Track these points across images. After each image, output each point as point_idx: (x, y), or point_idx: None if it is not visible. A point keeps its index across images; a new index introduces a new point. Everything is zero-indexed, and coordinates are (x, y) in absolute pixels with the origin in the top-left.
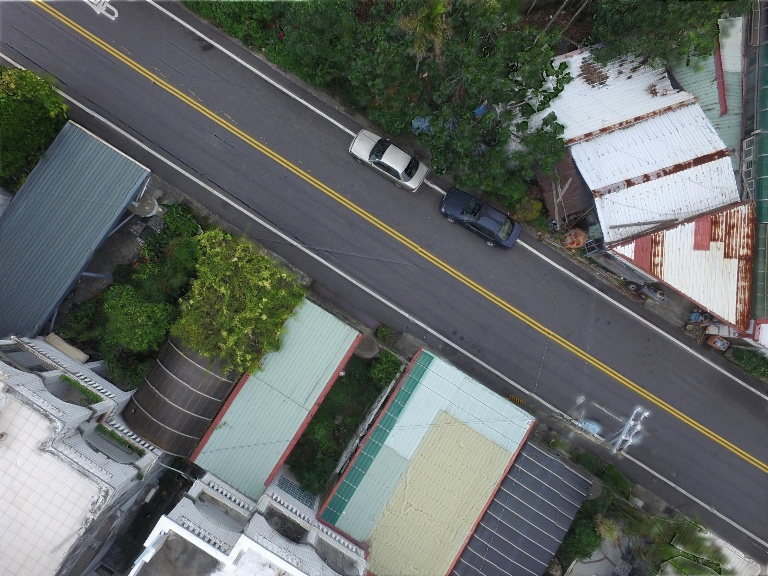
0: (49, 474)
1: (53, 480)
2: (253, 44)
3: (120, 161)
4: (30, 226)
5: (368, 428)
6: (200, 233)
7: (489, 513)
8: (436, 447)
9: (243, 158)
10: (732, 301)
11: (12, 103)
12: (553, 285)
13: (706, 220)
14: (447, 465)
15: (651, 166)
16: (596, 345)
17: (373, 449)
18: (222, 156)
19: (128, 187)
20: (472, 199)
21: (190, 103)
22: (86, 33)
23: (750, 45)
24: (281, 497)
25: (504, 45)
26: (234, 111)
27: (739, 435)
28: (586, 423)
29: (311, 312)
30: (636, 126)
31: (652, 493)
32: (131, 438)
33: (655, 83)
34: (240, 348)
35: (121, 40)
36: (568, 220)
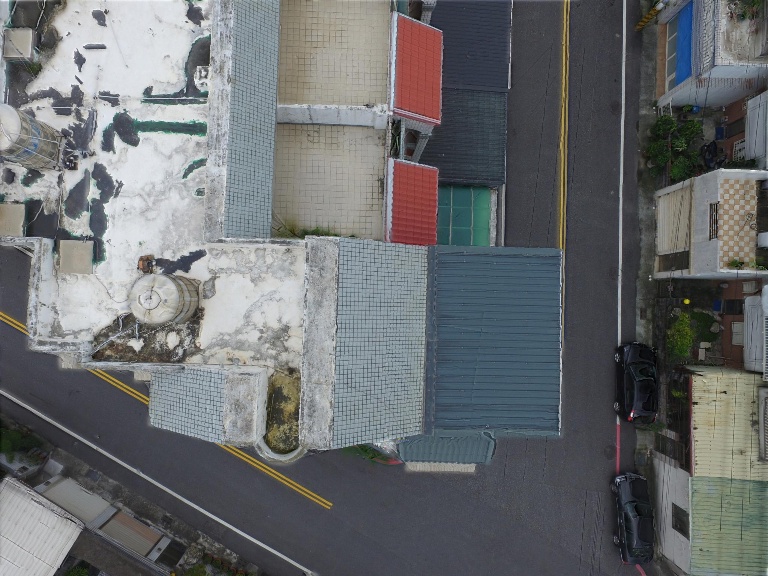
0: None
1: None
2: None
3: None
4: None
5: None
6: None
7: None
8: None
9: None
10: None
11: None
12: None
13: None
14: None
15: None
16: (15, 304)
17: None
18: None
19: None
20: None
21: None
22: None
23: None
24: None
25: None
26: None
27: None
28: None
29: None
30: None
31: (73, 456)
32: None
33: None
34: None
35: None
36: None
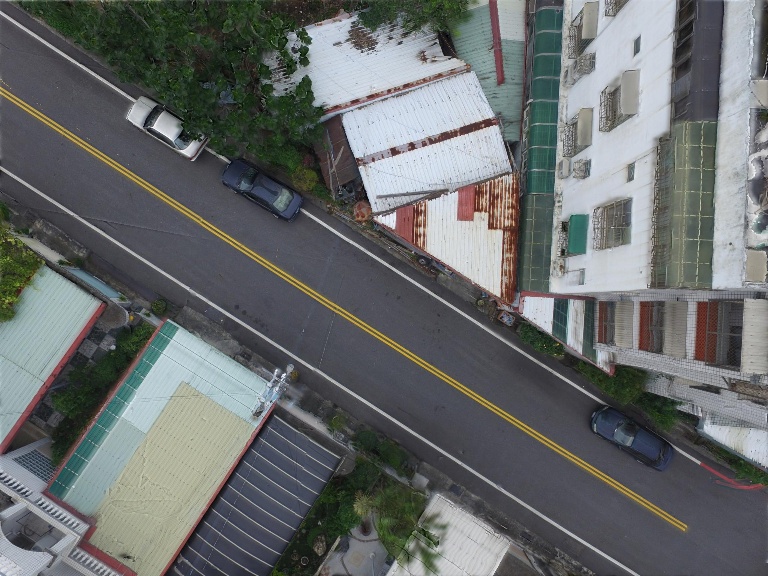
0: None
1: None
2: None
3: None
4: None
5: None
6: None
7: (230, 487)
8: (177, 420)
9: (18, 124)
10: (497, 273)
11: None
12: (342, 259)
13: (469, 190)
14: (188, 438)
15: (418, 134)
16: (384, 320)
17: (110, 422)
18: None
19: None
20: (250, 169)
21: None
22: None
23: (529, 12)
24: (5, 470)
25: None
26: (8, 75)
27: (528, 412)
28: None
29: (52, 280)
30: (410, 94)
31: (438, 471)
32: None
33: (425, 49)
34: None
35: None
36: (354, 192)
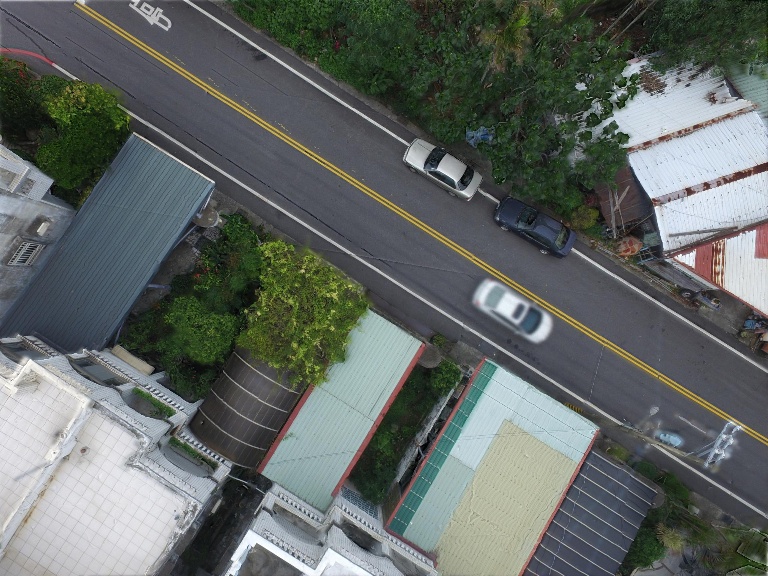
0: (131, 488)
1: (136, 494)
2: (306, 54)
3: (185, 173)
4: (96, 239)
5: (428, 437)
6: (262, 244)
7: (555, 523)
8: (501, 457)
9: (297, 168)
10: None
11: (83, 117)
12: (607, 293)
13: (767, 228)
14: (512, 475)
15: (711, 174)
16: (650, 353)
17: (439, 459)
18: (276, 166)
19: (193, 199)
20: (527, 207)
21: (244, 113)
22: (140, 44)
23: None
24: (349, 508)
25: None
26: (288, 121)
27: None
28: (667, 435)
29: (374, 322)
30: (694, 134)
31: (708, 500)
32: (202, 450)
33: (713, 91)
34: (309, 360)
35: (175, 50)
36: (622, 228)
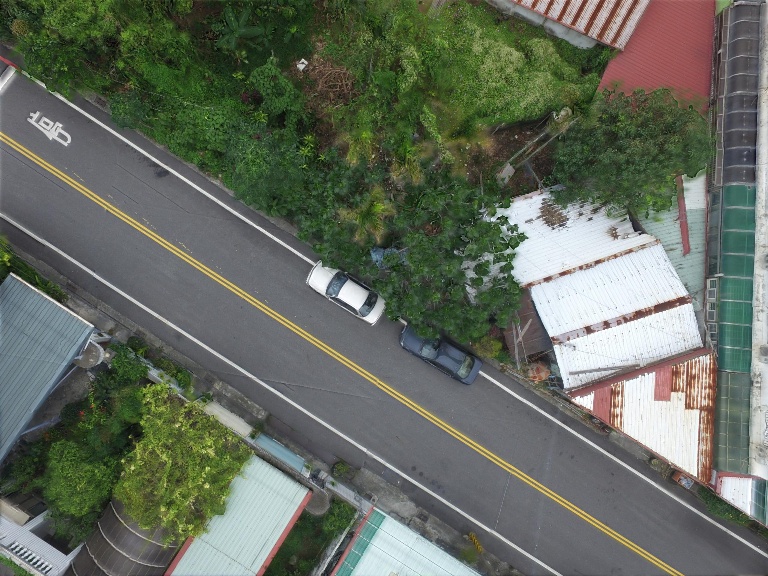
0: None
1: None
2: (209, 170)
3: (62, 316)
4: None
5: None
6: (146, 385)
7: None
8: None
9: (198, 288)
10: (693, 452)
11: None
12: (515, 418)
13: (667, 370)
14: None
15: (611, 312)
16: (559, 480)
17: None
18: (176, 286)
19: (70, 344)
20: None
21: (144, 232)
22: (37, 160)
23: (714, 184)
24: None
25: (452, 218)
26: (189, 240)
27: (704, 573)
28: None
29: (260, 468)
30: (597, 267)
31: None
32: None
33: (616, 225)
34: (181, 520)
35: (74, 167)
36: None
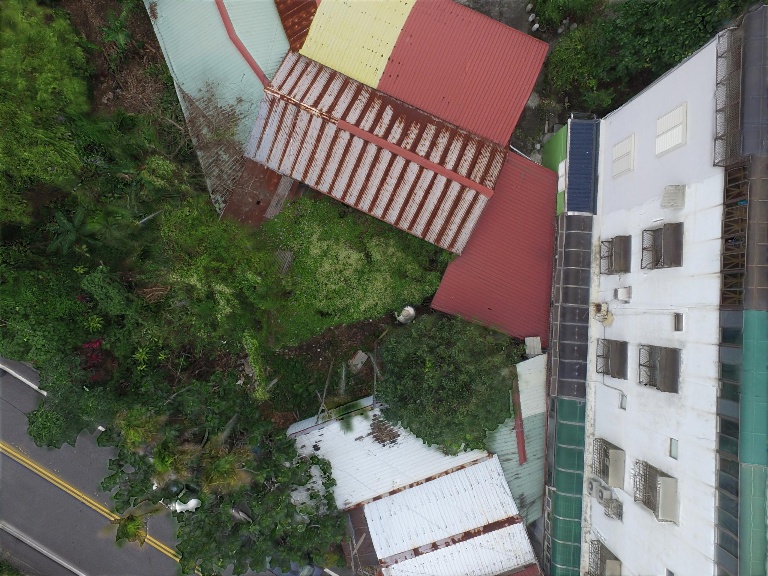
0: None
1: None
2: None
3: None
4: None
5: None
6: None
7: None
8: None
9: (36, 492)
10: None
11: None
12: None
13: None
14: None
15: (441, 532)
16: None
17: None
18: (13, 491)
19: None
20: None
21: None
22: None
23: None
24: None
25: None
26: (26, 443)
27: None
28: None
29: None
30: None
31: None
32: None
33: None
34: None
35: None
36: None
